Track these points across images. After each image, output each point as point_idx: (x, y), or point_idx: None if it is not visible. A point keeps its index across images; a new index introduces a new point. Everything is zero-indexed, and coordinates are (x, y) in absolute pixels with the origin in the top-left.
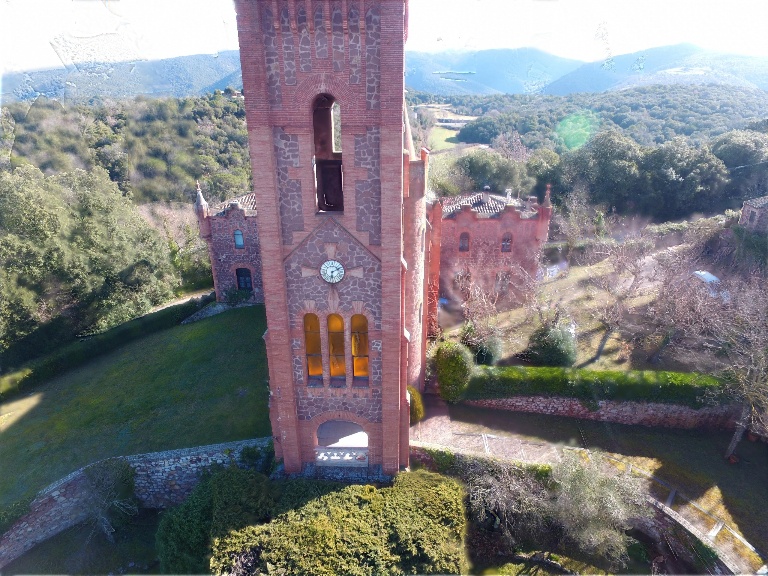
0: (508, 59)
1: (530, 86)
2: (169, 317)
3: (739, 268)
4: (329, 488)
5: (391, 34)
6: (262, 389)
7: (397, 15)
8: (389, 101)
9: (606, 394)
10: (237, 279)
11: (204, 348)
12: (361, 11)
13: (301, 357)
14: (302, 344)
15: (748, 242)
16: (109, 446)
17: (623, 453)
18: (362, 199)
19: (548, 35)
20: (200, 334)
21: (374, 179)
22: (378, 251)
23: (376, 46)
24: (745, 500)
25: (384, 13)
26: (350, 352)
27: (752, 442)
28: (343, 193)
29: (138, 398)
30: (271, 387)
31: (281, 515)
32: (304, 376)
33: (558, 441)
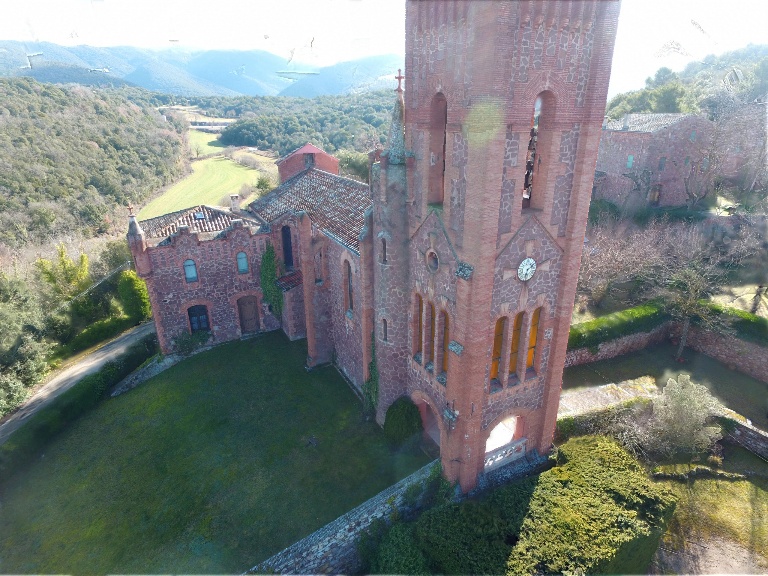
0: (336, 61)
1: (356, 88)
2: (91, 393)
3: (610, 227)
4: (529, 485)
5: (609, 37)
6: (333, 429)
7: (615, 20)
8: (598, 99)
9: (602, 338)
10: (189, 320)
11: (201, 412)
12: (593, 13)
13: (488, 365)
14: (492, 351)
15: (590, 208)
16: (195, 569)
17: (631, 378)
18: (558, 194)
19: (367, 40)
20: (172, 398)
21: (569, 173)
22: (562, 242)
23: (589, 47)
24: (707, 384)
25: (607, 17)
26: (528, 346)
27: (676, 346)
28: (546, 189)
29: (169, 499)
30: (458, 406)
31: (522, 527)
32: (488, 384)
33: (594, 384)
